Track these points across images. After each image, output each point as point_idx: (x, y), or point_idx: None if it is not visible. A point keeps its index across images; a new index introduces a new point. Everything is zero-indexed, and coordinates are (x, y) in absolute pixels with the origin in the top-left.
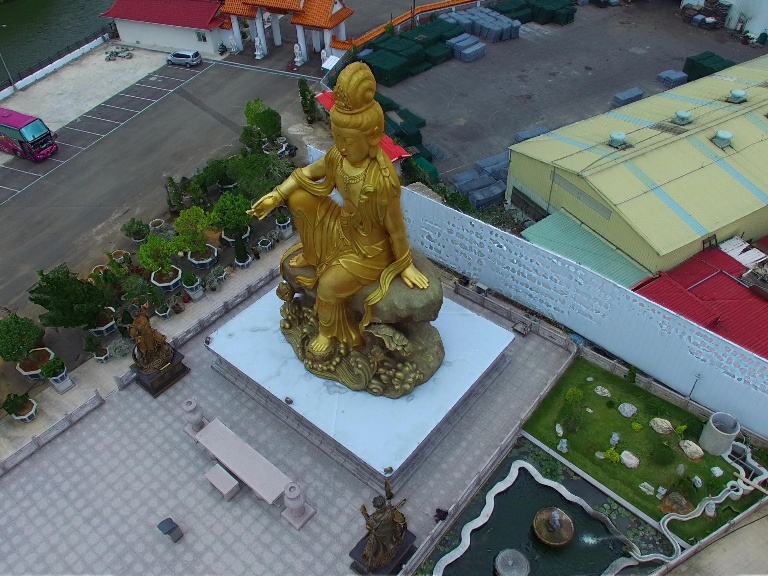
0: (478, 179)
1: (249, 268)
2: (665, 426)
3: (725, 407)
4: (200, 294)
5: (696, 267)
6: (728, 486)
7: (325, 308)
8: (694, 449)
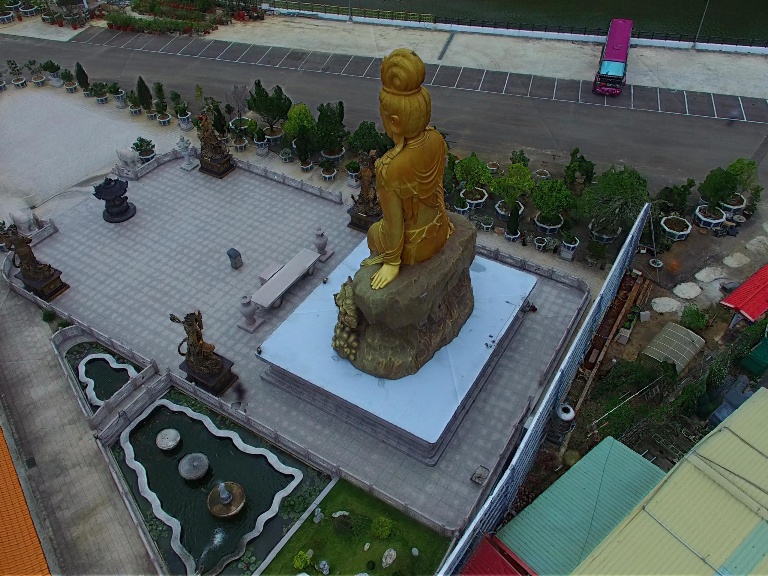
0: None
1: (508, 242)
2: None
3: None
4: None
5: None
6: None
7: None
8: None
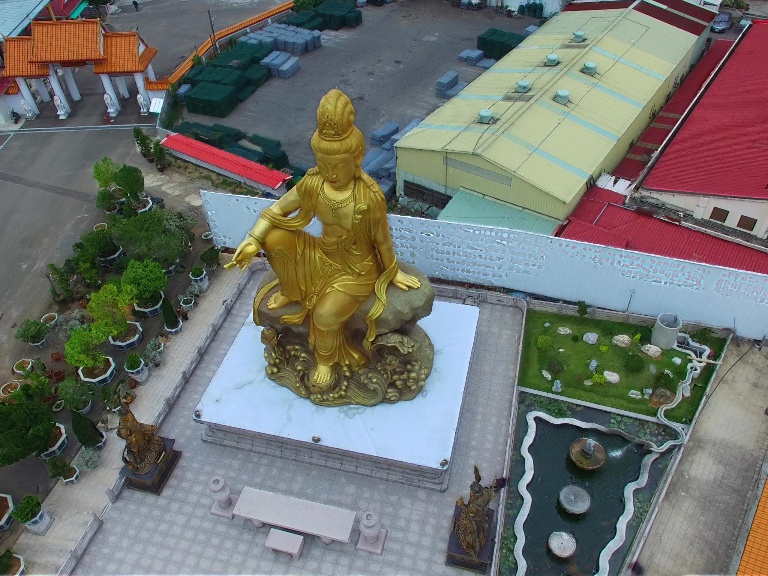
0: None
1: (183, 332)
2: (626, 340)
3: (657, 309)
4: (146, 374)
5: (589, 206)
6: (689, 369)
7: (327, 337)
8: (655, 350)
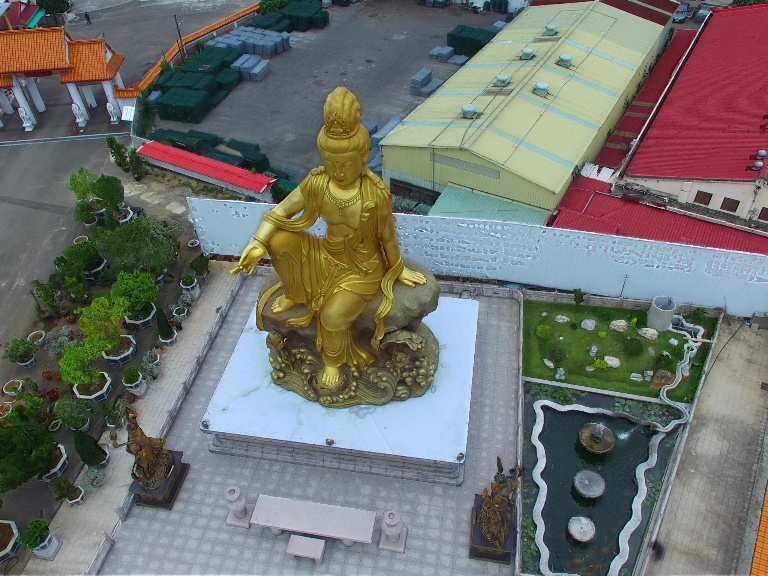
0: None
1: (178, 342)
2: (623, 325)
3: (650, 293)
4: (144, 388)
5: (576, 195)
6: (686, 349)
7: (335, 338)
8: (652, 332)
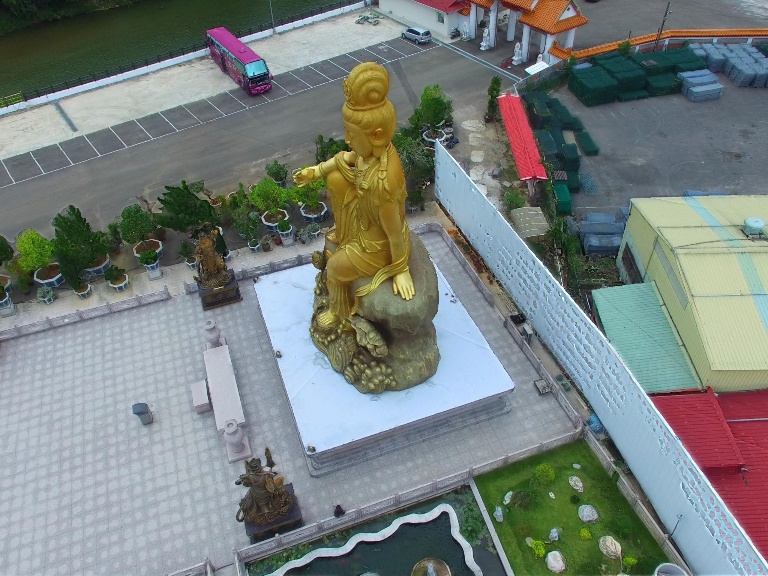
0: (605, 224)
1: None
2: (612, 549)
3: (701, 566)
4: (290, 242)
5: (765, 401)
6: None
7: (329, 285)
8: None
